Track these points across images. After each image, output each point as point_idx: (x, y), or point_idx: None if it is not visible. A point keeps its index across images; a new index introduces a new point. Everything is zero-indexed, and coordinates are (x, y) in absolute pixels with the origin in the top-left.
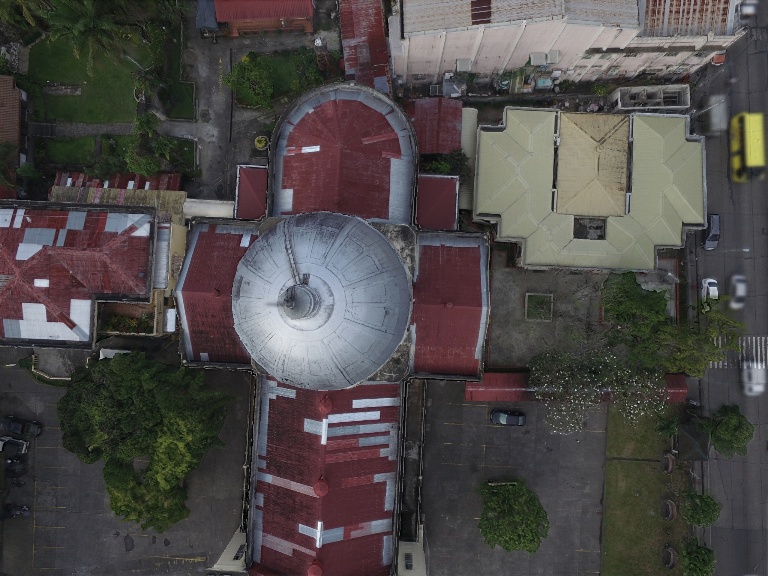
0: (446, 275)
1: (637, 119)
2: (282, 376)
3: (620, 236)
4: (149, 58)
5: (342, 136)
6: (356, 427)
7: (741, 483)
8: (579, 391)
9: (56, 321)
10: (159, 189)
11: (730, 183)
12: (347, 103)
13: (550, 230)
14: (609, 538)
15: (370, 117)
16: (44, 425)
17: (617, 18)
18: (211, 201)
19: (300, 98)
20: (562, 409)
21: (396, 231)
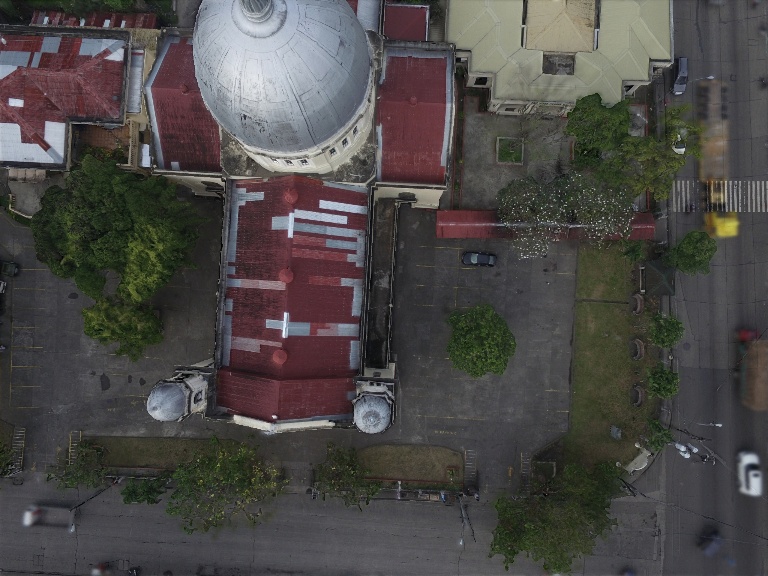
0: (412, 79)
1: None
2: (240, 110)
3: (588, 70)
4: None
5: None
6: (323, 227)
7: (708, 323)
8: (545, 209)
9: (31, 142)
10: (135, 27)
11: (699, 30)
12: None
13: (519, 63)
14: (578, 378)
15: None
16: (21, 266)
17: None
18: None
19: None
20: (529, 231)
21: None
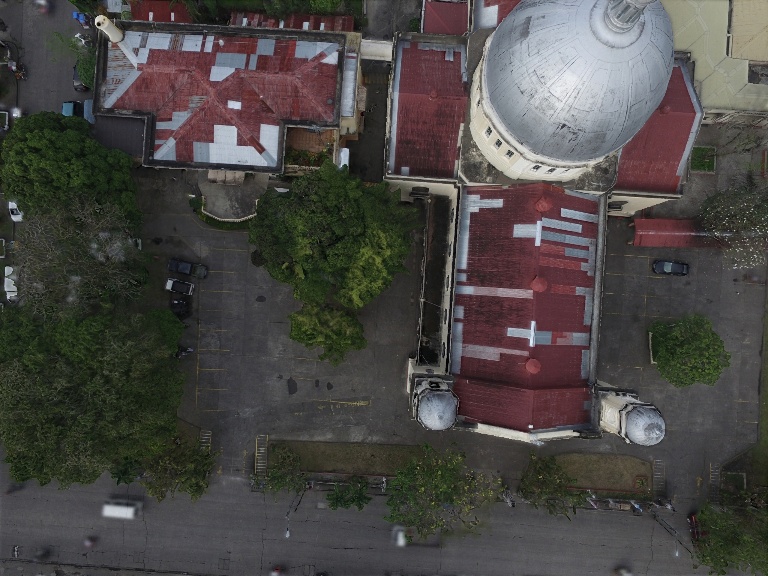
0: None
1: None
2: (562, 120)
3: None
4: None
5: None
6: (563, 236)
7: None
8: (766, 220)
9: (246, 145)
10: (334, 30)
11: None
12: None
13: (727, 72)
14: (767, 389)
15: None
16: (209, 268)
17: None
18: (387, 42)
19: None
20: (745, 241)
21: None
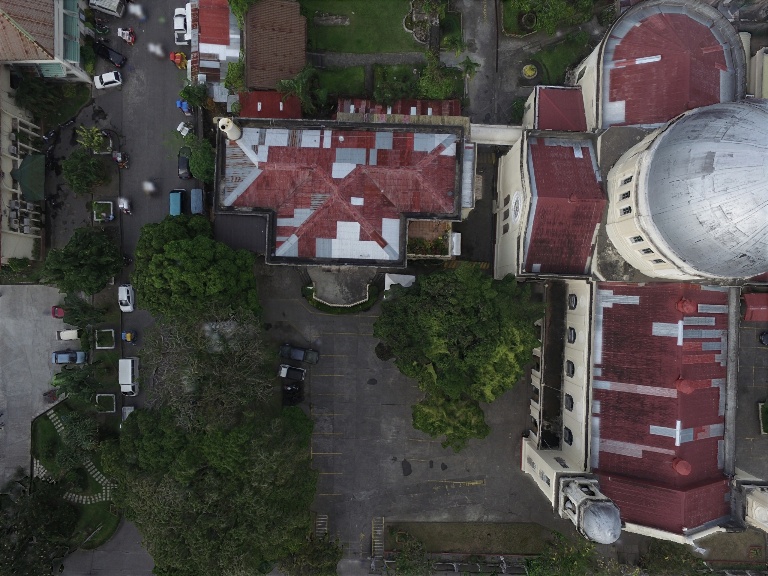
0: None
1: None
2: (744, 251)
3: None
4: None
5: (687, 44)
6: (700, 331)
7: None
8: None
9: (368, 240)
10: (442, 115)
11: None
12: (674, 16)
13: None
14: None
15: (700, 29)
16: (320, 353)
17: None
18: (495, 126)
19: (630, 11)
20: None
21: None
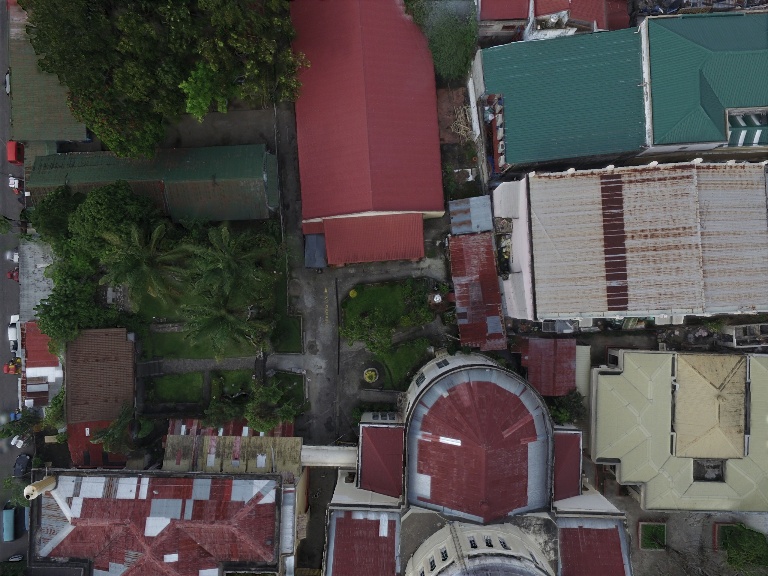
0: (589, 567)
1: (754, 360)
2: None
3: (740, 480)
4: (255, 291)
5: (485, 434)
6: None
7: None
8: None
9: None
10: (274, 435)
11: None
12: (482, 386)
13: (671, 477)
14: None
15: (506, 402)
16: None
17: (752, 300)
18: (327, 448)
19: None
20: None
21: (539, 524)
